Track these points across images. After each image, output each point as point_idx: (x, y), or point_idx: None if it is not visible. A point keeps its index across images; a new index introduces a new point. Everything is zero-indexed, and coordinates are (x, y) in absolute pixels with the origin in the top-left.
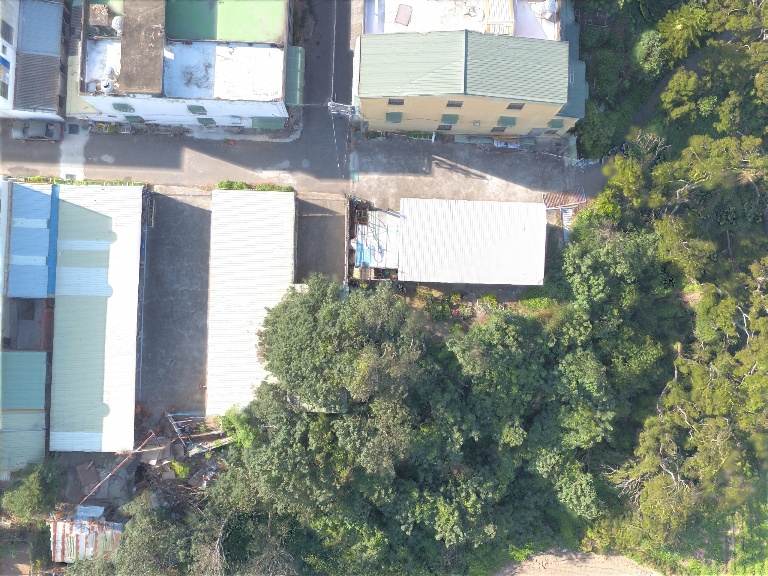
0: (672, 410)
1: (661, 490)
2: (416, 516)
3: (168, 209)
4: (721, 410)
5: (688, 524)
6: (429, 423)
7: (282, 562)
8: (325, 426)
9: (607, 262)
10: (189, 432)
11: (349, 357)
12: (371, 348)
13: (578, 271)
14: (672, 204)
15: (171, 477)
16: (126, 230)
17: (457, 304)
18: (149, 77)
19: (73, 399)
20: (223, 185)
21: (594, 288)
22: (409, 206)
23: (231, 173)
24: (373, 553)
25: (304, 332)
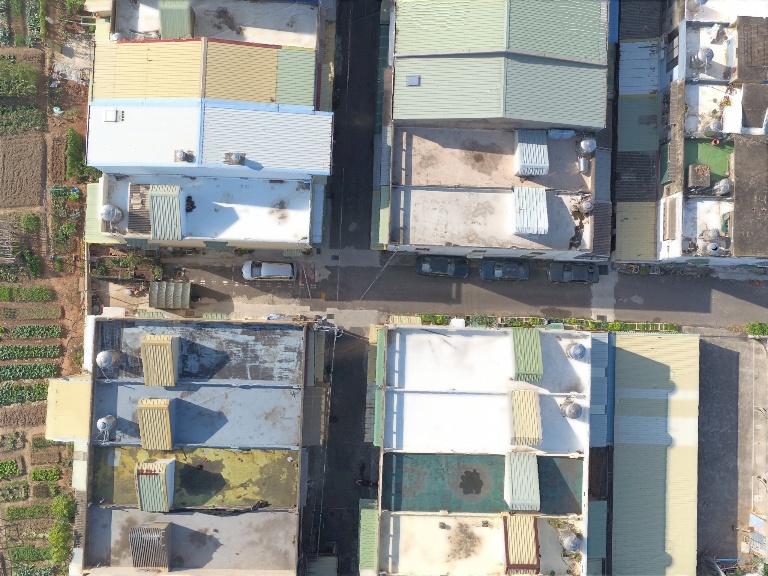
0: None
1: None
2: None
3: None
4: None
5: None
6: None
7: None
8: None
9: None
10: (729, 575)
11: None
12: None
13: None
14: None
15: None
16: (684, 379)
17: None
18: (762, 241)
19: (635, 548)
20: (756, 328)
21: None
22: None
23: (757, 314)
24: None
25: None
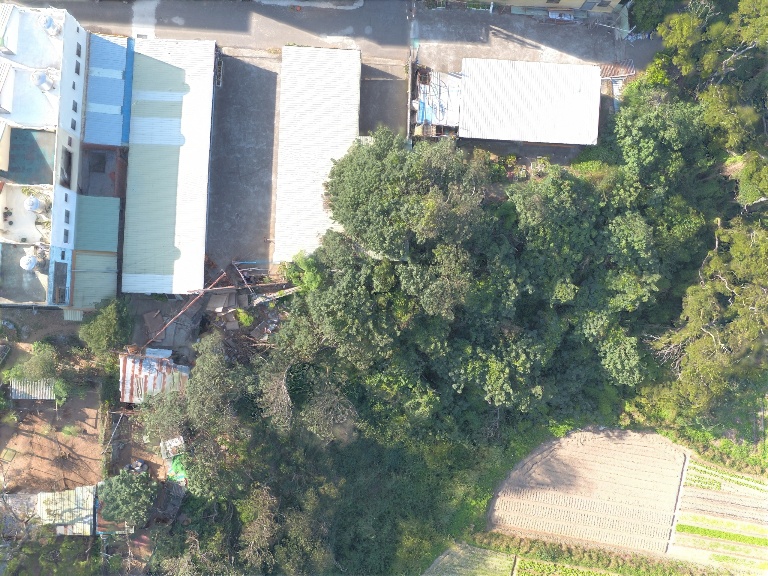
0: (713, 278)
1: (702, 354)
2: (468, 373)
3: (236, 70)
4: (759, 280)
5: (721, 402)
6: (485, 278)
7: (342, 408)
8: (388, 271)
9: (656, 128)
10: (254, 282)
11: (416, 198)
12: (435, 194)
13: (629, 134)
14: (718, 75)
15: (235, 327)
16: (199, 82)
17: (512, 167)
18: None
19: (145, 243)
20: None
21: (644, 151)
22: (470, 65)
23: (297, 37)
24: (426, 409)
25: (373, 174)
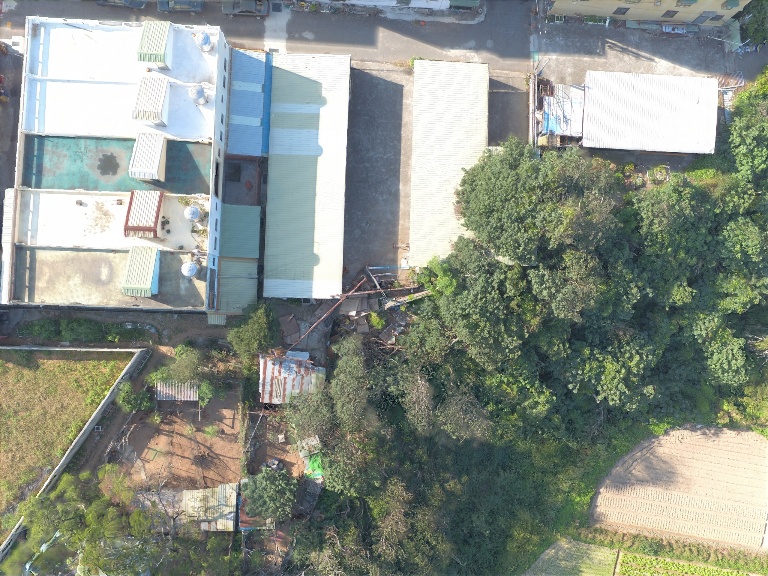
0: None
1: None
2: (585, 374)
3: (364, 83)
4: None
5: None
6: (605, 282)
7: (470, 408)
8: (519, 276)
9: (767, 138)
10: (385, 286)
11: (552, 206)
12: (566, 202)
13: (744, 143)
14: None
15: (365, 330)
16: (335, 95)
17: (629, 175)
18: None
19: (286, 249)
20: None
21: (758, 159)
22: (594, 78)
23: (421, 51)
24: (544, 408)
25: (510, 183)
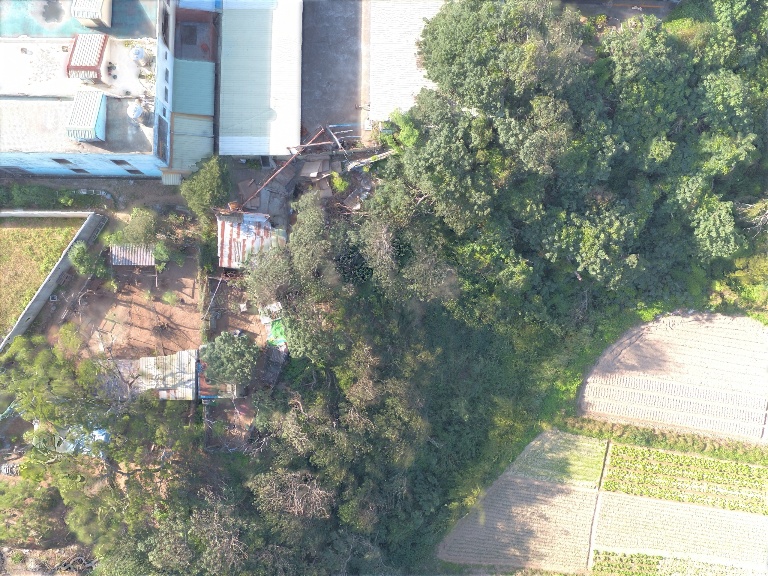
0: None
1: None
2: (562, 240)
3: None
4: None
5: None
6: (579, 137)
7: (439, 271)
8: (485, 126)
9: None
10: (348, 147)
11: (515, 43)
12: None
13: None
14: None
15: (328, 195)
16: None
17: (602, 28)
18: None
19: (241, 105)
20: None
21: (737, 4)
22: None
23: None
24: (520, 277)
25: (471, 22)
